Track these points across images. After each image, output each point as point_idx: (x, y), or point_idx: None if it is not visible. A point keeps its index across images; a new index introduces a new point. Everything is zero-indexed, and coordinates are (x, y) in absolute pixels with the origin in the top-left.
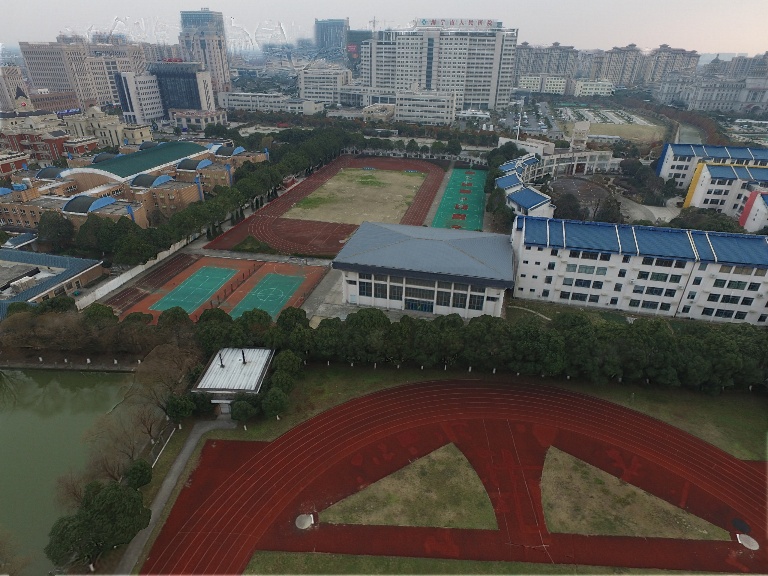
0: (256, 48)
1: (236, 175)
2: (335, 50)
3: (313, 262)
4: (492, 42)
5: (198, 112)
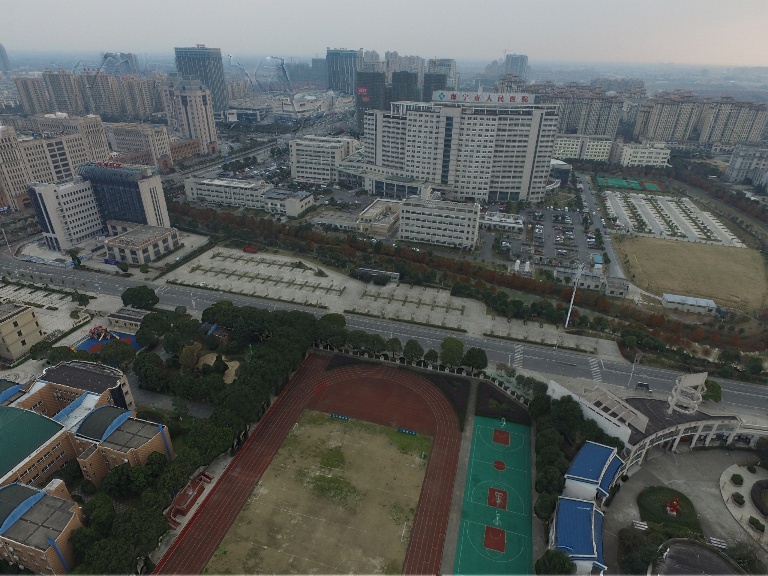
0: (257, 87)
1: (72, 542)
2: (336, 113)
3: None
4: (527, 121)
5: (141, 231)
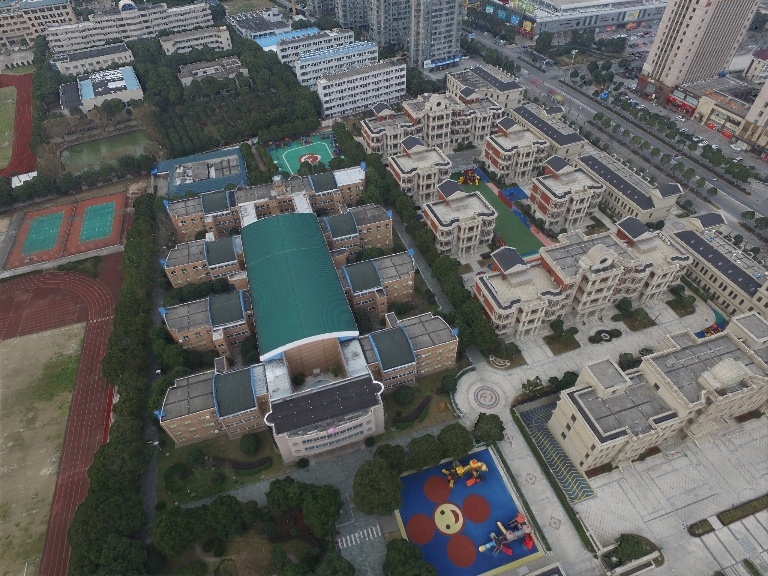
0: None
1: None
2: None
3: (20, 270)
4: None
5: None
